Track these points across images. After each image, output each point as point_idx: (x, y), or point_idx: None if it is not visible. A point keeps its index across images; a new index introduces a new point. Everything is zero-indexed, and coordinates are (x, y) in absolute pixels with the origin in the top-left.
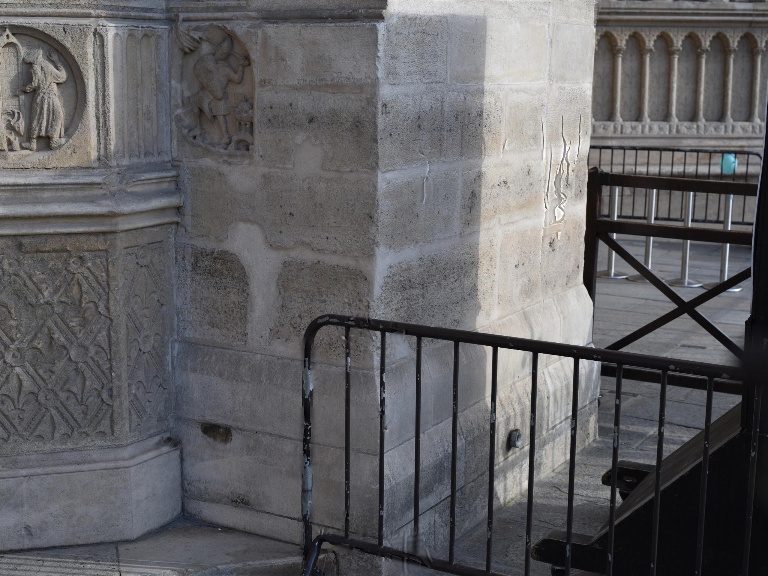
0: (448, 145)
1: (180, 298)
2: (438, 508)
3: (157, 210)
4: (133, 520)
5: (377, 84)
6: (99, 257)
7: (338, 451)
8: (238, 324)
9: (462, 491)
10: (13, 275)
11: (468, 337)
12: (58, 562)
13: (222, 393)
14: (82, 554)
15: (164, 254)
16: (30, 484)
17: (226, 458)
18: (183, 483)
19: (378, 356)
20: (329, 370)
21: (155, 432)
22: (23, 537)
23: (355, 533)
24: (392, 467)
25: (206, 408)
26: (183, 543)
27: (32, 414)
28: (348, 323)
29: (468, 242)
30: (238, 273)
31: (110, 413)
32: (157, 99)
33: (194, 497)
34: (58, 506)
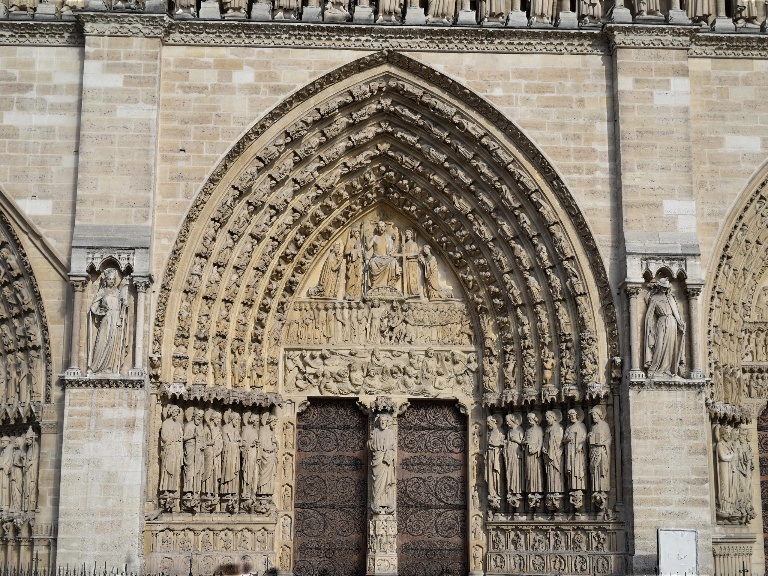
0: (654, 574)
1: None
2: None
3: None
4: None
5: (633, 564)
6: None
7: None
8: None
9: None
10: None
11: None
12: None
13: None
14: None
15: None
16: None
17: None
18: None
19: None
20: None
21: None
22: None
23: None
24: None
25: None
26: None
27: None
28: None
29: None
30: None
31: None
32: (622, 566)
33: None
34: None
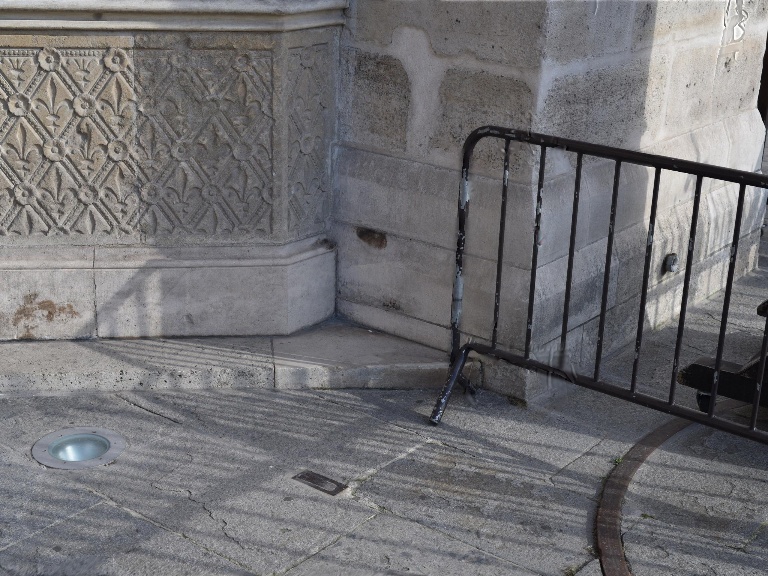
0: None
1: (342, 102)
2: (587, 326)
3: (323, 11)
4: (288, 316)
5: None
6: (264, 56)
7: (490, 263)
8: (398, 131)
9: (612, 311)
10: (181, 71)
11: (631, 157)
12: (216, 350)
13: (379, 199)
14: (239, 344)
15: (328, 56)
16: (192, 275)
17: (380, 263)
18: (337, 284)
19: (537, 171)
20: (486, 182)
21: (312, 233)
22: (185, 324)
23: (502, 344)
24: (543, 283)
25: (362, 213)
26: (335, 341)
27: (196, 208)
28: (509, 135)
29: (639, 58)
30: (401, 79)
31: (270, 212)
32: None
33: (347, 298)
34: (218, 298)
